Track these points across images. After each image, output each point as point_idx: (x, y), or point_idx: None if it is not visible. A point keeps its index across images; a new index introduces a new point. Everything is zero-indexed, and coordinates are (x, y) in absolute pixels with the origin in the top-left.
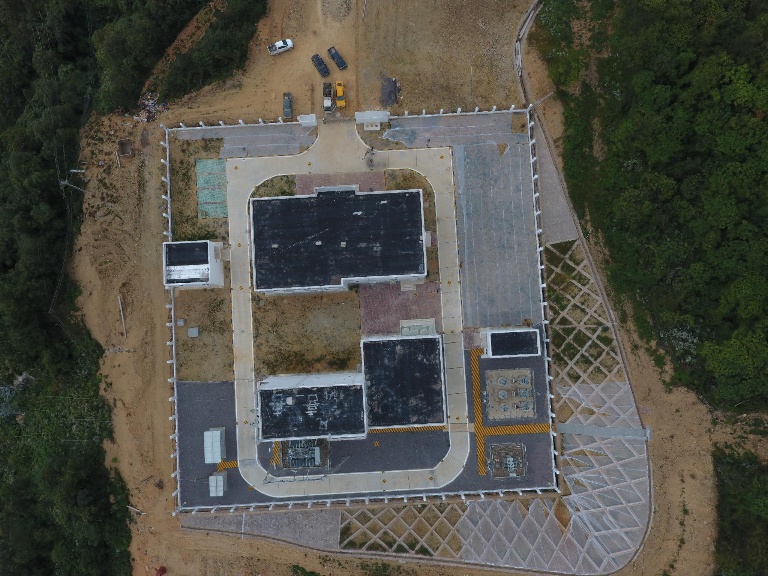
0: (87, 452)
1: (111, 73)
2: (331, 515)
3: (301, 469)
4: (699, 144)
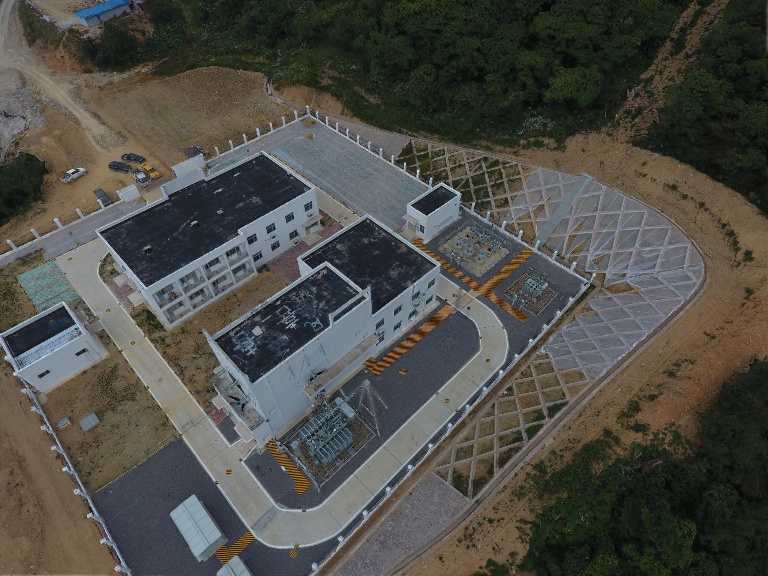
0: None
1: None
2: (426, 486)
3: (343, 468)
4: (421, 41)
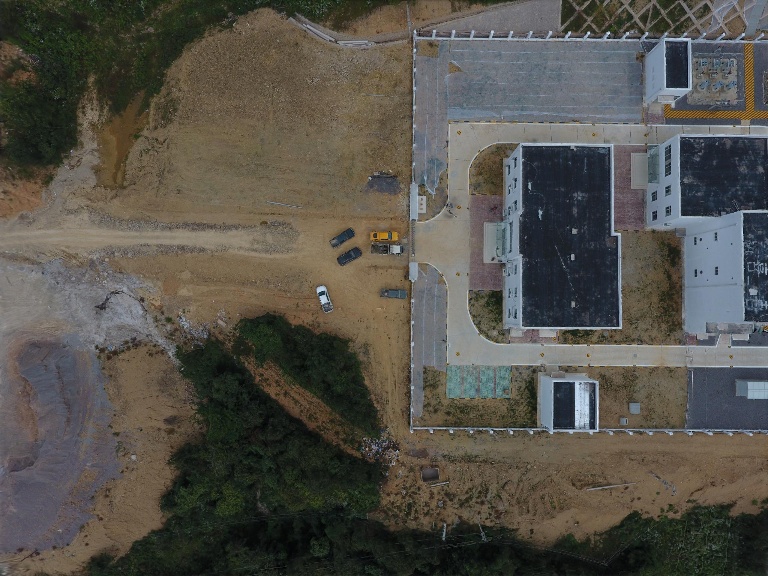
0: (747, 532)
1: (343, 488)
2: None
3: None
4: None
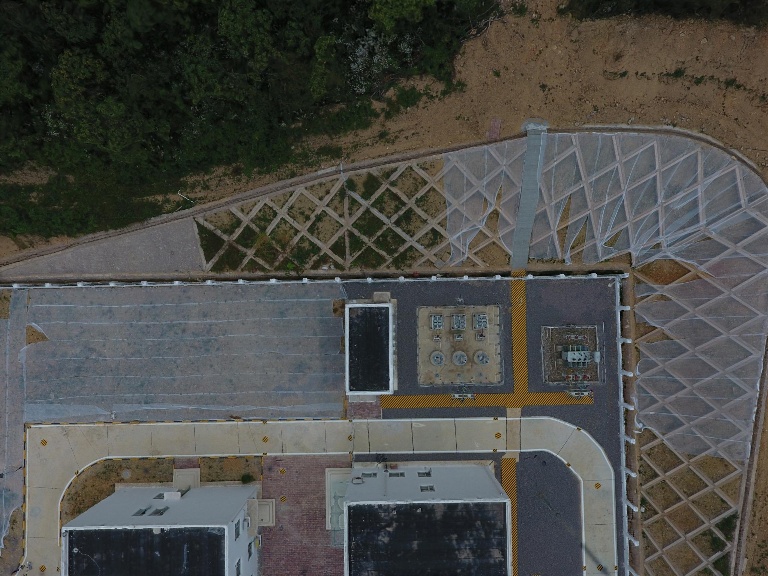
0: None
1: None
2: None
3: None
4: None
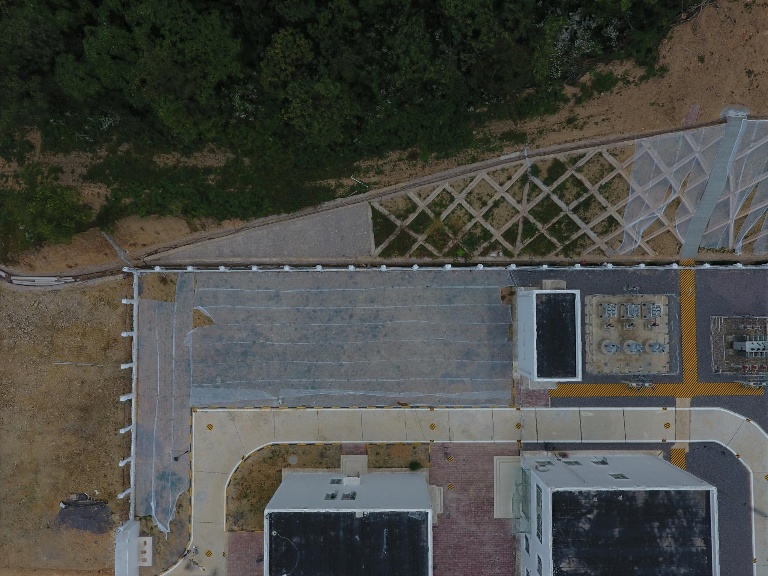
0: None
1: None
2: None
3: None
4: None
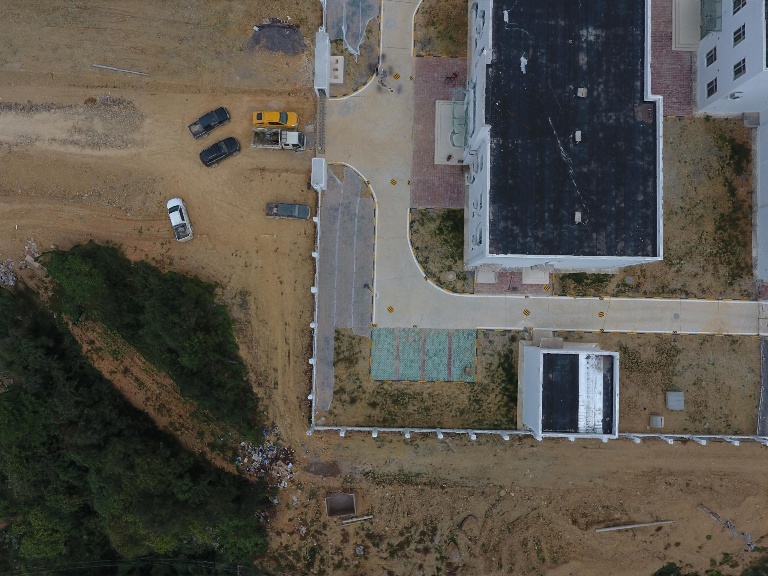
0: None
1: (199, 524)
2: None
3: None
4: None
